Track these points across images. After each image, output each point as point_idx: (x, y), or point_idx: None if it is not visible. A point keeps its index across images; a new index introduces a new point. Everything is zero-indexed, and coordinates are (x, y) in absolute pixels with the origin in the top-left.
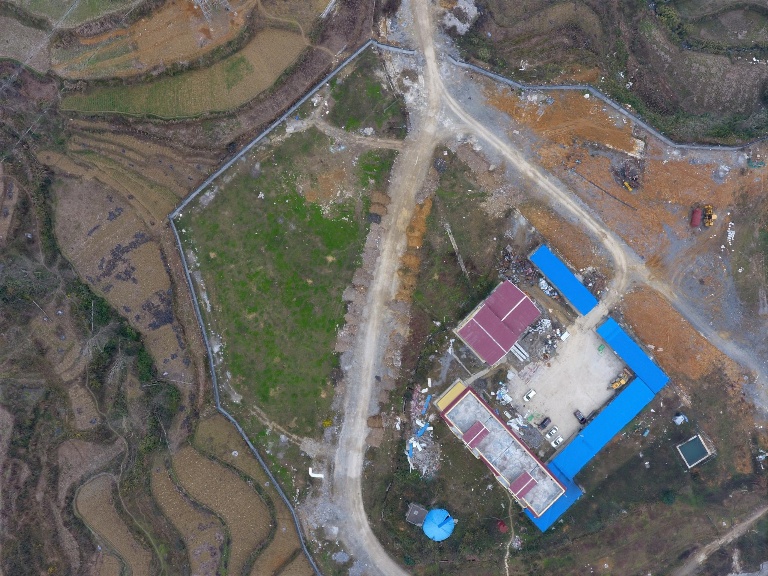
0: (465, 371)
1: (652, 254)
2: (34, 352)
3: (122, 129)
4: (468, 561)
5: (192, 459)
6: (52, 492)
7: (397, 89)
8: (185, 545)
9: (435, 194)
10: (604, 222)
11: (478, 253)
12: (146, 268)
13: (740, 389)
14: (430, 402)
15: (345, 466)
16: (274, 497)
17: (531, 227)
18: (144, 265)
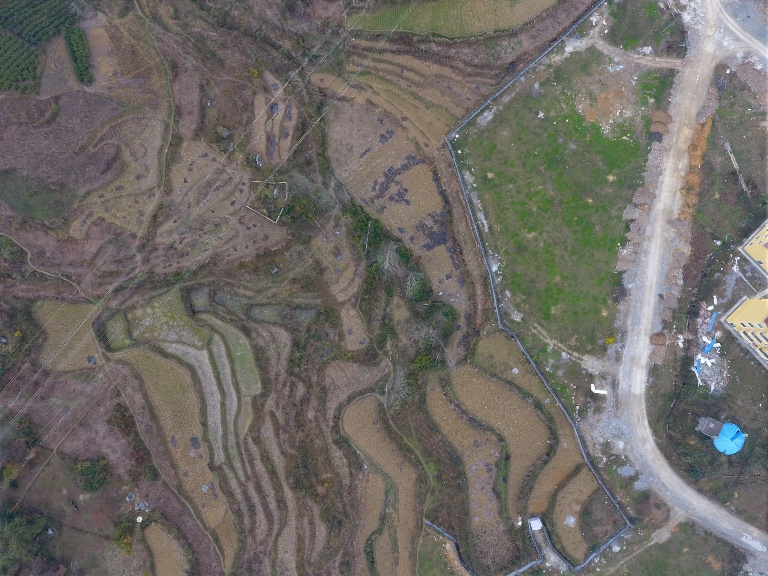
0: (750, 289)
1: None
2: (314, 271)
3: (404, 49)
4: (753, 476)
5: (470, 377)
6: (322, 411)
7: (674, 8)
8: (461, 461)
9: (715, 113)
10: None
11: (759, 172)
12: (418, 190)
13: None
14: (716, 319)
15: (629, 382)
16: (555, 413)
17: None
18: (416, 187)
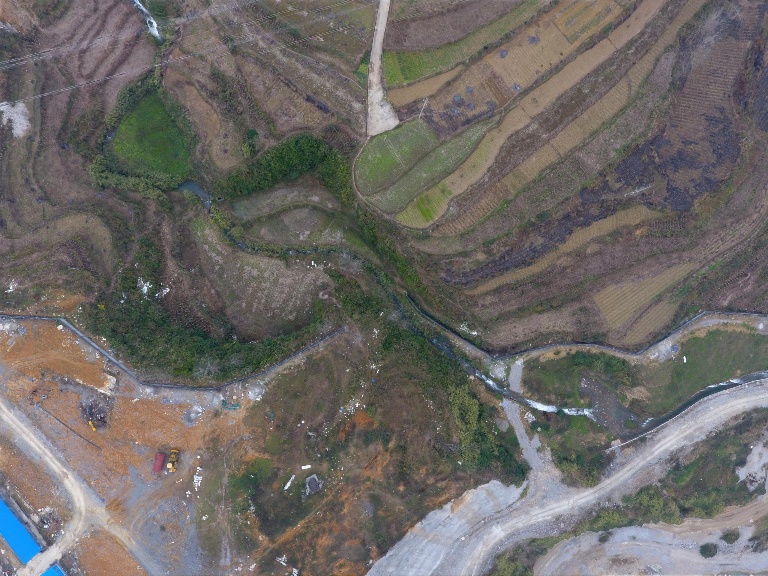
0: None
1: (113, 497)
2: None
3: None
4: None
5: None
6: None
7: None
8: None
9: None
10: (66, 461)
11: None
12: None
13: None
14: None
15: None
16: None
17: None
18: None
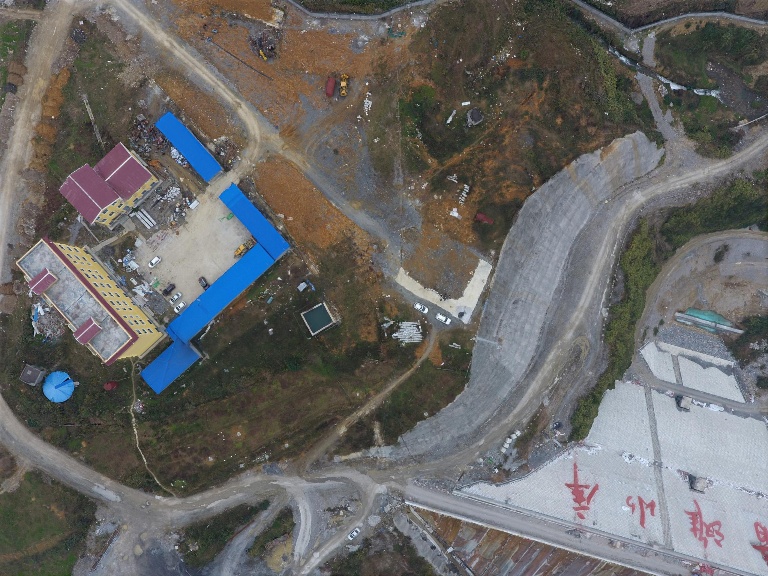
0: (93, 238)
1: (286, 124)
2: None
3: None
4: (94, 425)
5: None
6: None
7: None
8: None
9: (73, 65)
10: (239, 92)
11: (114, 123)
12: None
13: (369, 258)
14: None
15: None
16: None
17: (166, 97)
18: None
